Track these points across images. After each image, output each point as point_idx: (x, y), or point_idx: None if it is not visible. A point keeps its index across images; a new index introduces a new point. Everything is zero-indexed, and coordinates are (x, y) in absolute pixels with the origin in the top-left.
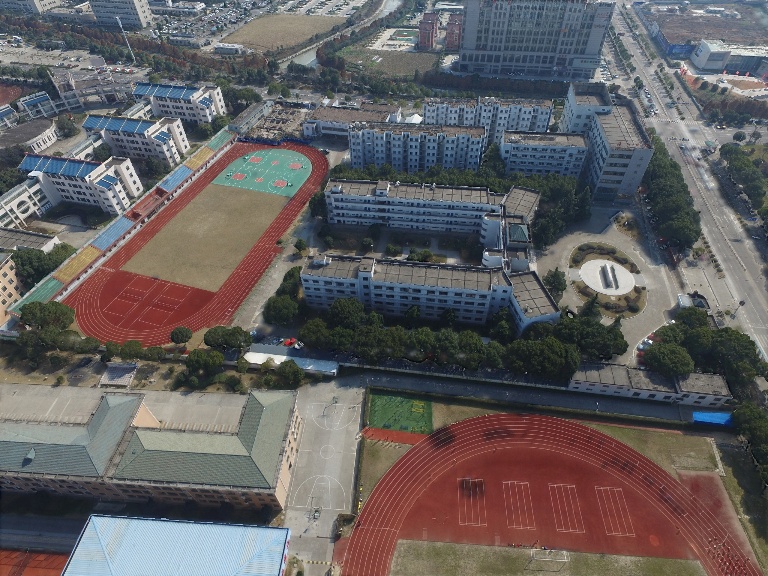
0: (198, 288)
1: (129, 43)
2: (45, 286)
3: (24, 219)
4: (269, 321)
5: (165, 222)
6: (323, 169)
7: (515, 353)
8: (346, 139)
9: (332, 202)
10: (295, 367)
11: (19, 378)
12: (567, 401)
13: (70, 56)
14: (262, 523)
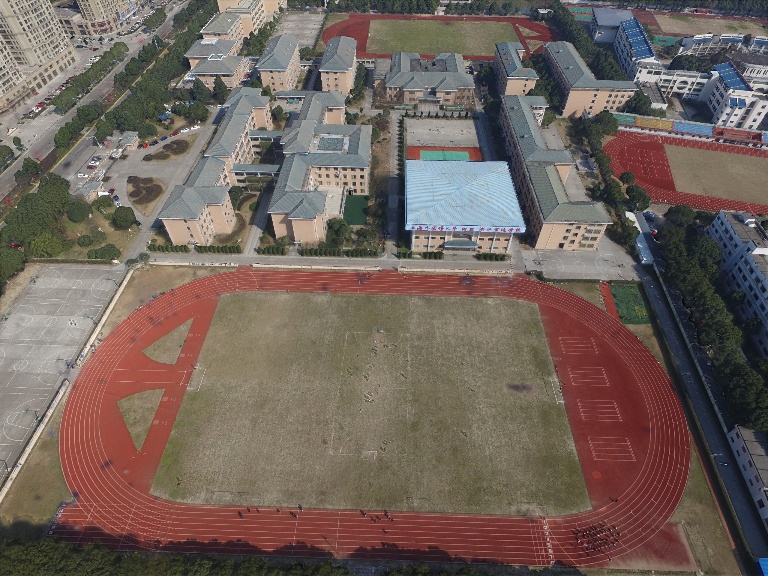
0: (674, 182)
1: None
2: (627, 117)
3: (674, 92)
4: (666, 214)
5: (727, 151)
6: None
7: (738, 368)
8: None
9: None
10: (634, 233)
11: (563, 134)
12: (712, 434)
13: None
14: (524, 239)
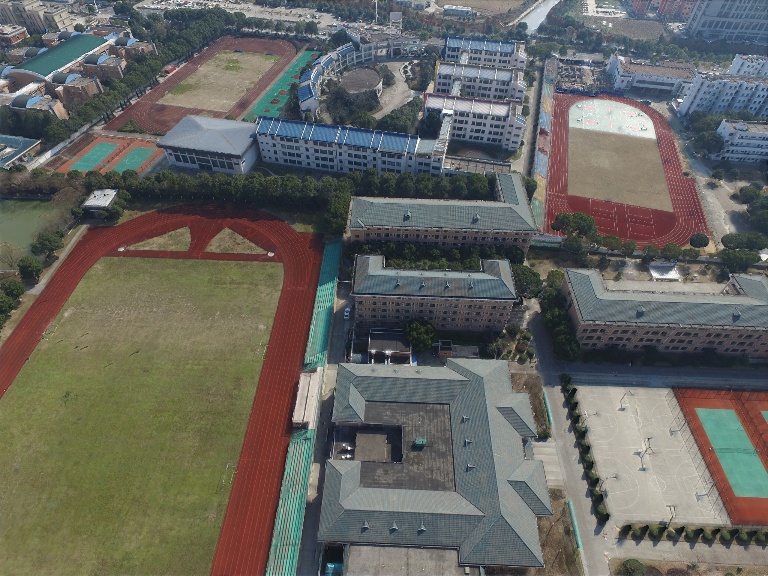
0: (655, 209)
1: (345, 3)
2: (535, 204)
3: None
4: (766, 230)
5: (565, 157)
6: (659, 117)
7: None
8: (653, 92)
9: (735, 139)
10: None
11: None
12: None
13: (301, 13)
14: None
